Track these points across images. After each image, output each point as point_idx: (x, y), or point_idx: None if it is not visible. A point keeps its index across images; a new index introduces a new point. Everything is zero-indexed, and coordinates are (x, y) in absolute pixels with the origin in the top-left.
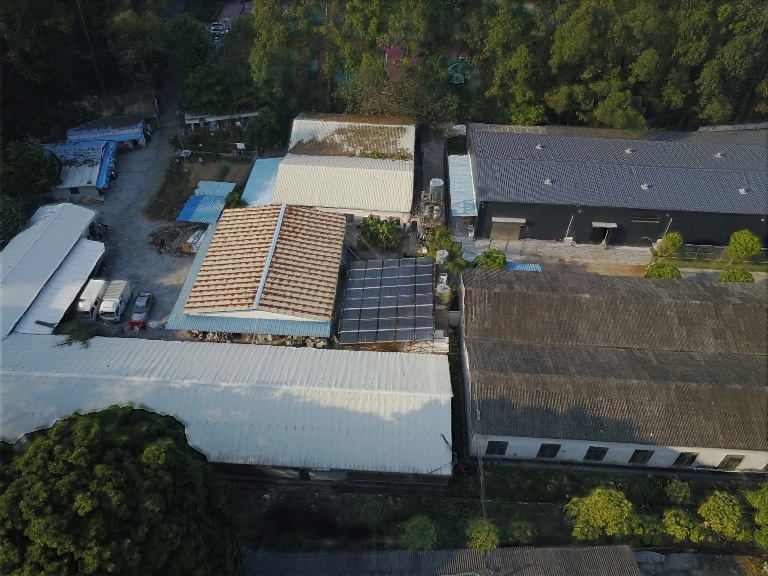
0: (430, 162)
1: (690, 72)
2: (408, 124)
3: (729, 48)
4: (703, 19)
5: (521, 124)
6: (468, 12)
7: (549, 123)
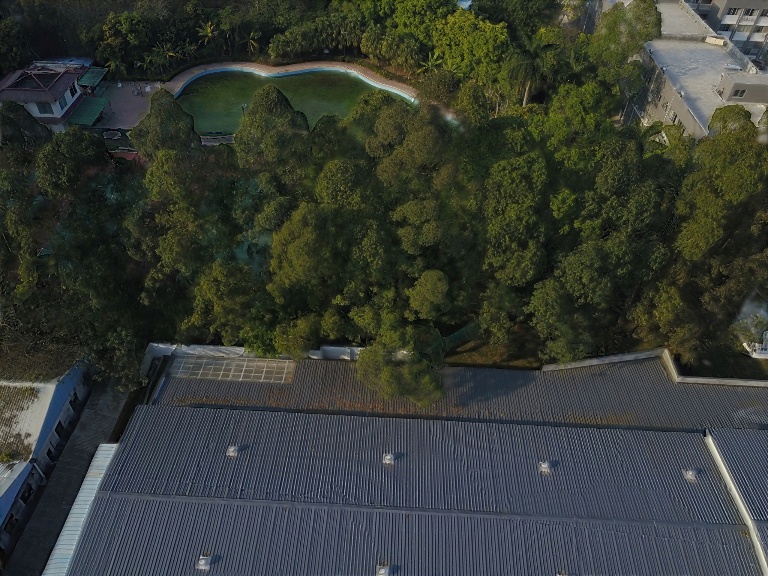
0: (76, 448)
1: (516, 292)
2: (47, 379)
3: (571, 265)
4: (524, 218)
5: (261, 355)
6: (127, 203)
7: (318, 341)
